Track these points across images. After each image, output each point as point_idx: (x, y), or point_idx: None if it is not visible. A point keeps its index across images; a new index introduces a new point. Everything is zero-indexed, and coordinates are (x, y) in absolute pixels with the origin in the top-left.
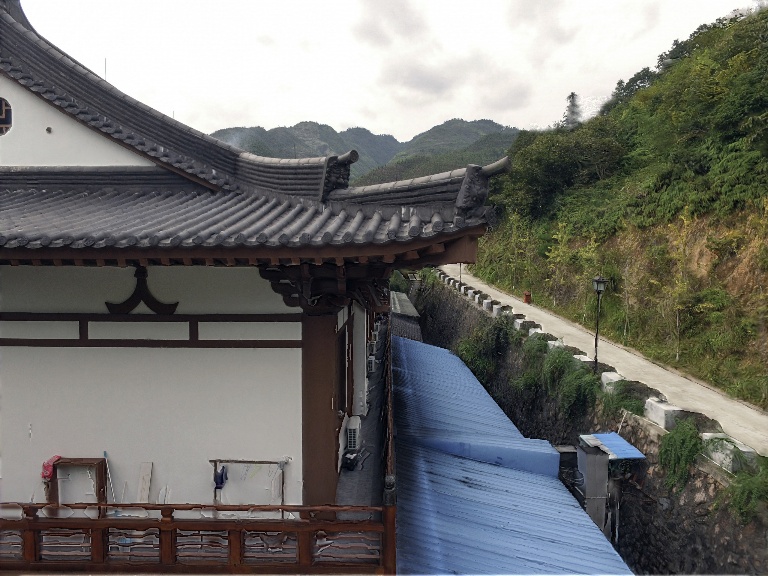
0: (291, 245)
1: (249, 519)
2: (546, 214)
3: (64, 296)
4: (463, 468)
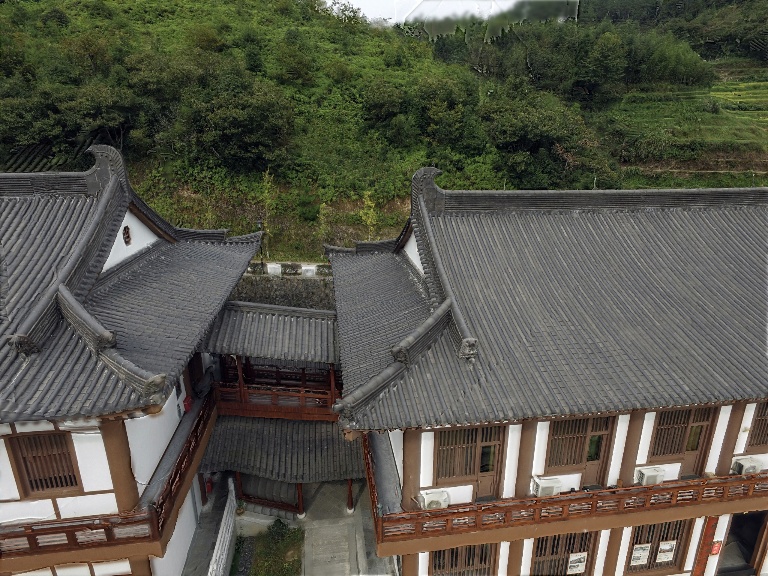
0: None
1: None
2: (262, 170)
3: None
4: None
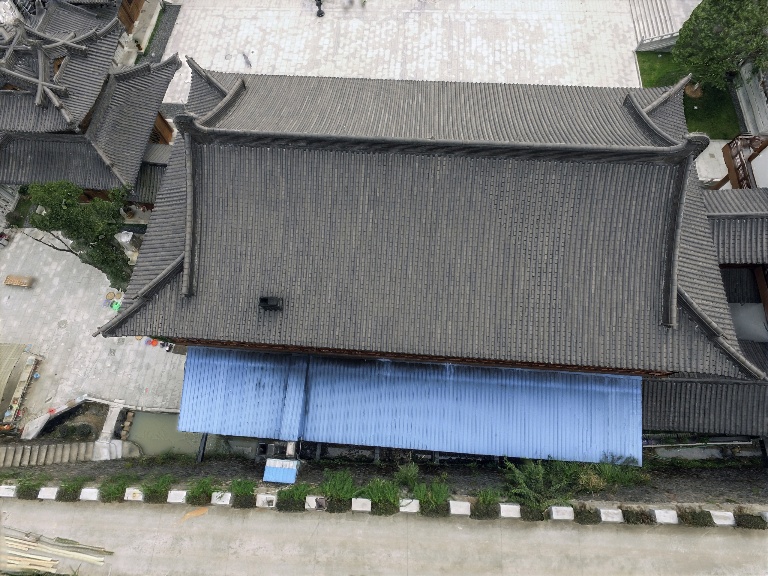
0: None
1: None
2: None
3: None
4: (274, 386)
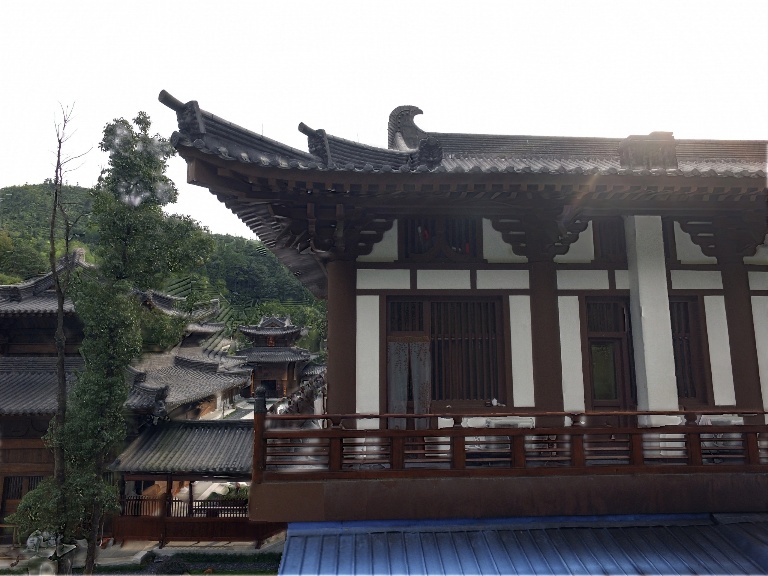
0: None
1: None
2: None
3: None
4: None
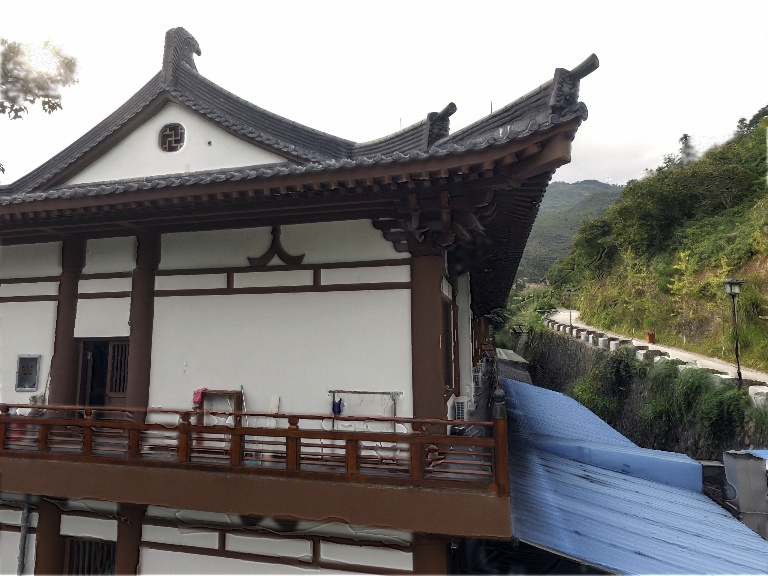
0: (402, 160)
1: (365, 431)
2: (665, 250)
3: (217, 254)
4: (583, 469)
